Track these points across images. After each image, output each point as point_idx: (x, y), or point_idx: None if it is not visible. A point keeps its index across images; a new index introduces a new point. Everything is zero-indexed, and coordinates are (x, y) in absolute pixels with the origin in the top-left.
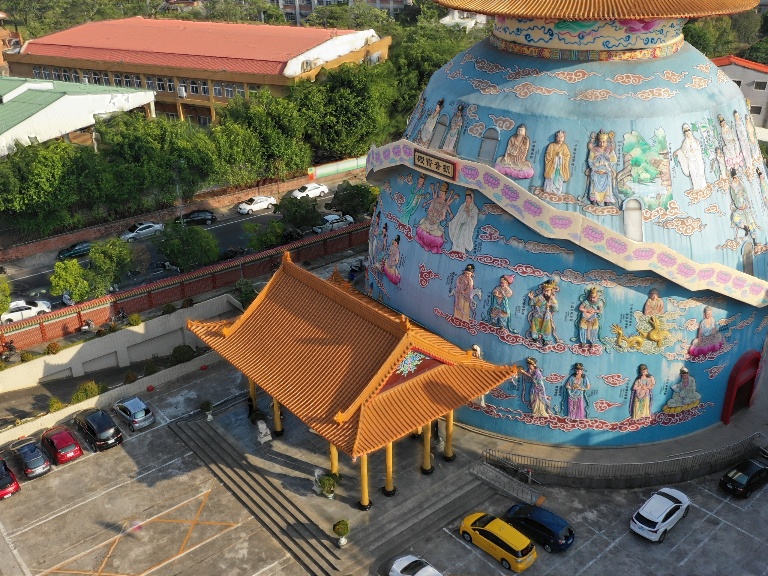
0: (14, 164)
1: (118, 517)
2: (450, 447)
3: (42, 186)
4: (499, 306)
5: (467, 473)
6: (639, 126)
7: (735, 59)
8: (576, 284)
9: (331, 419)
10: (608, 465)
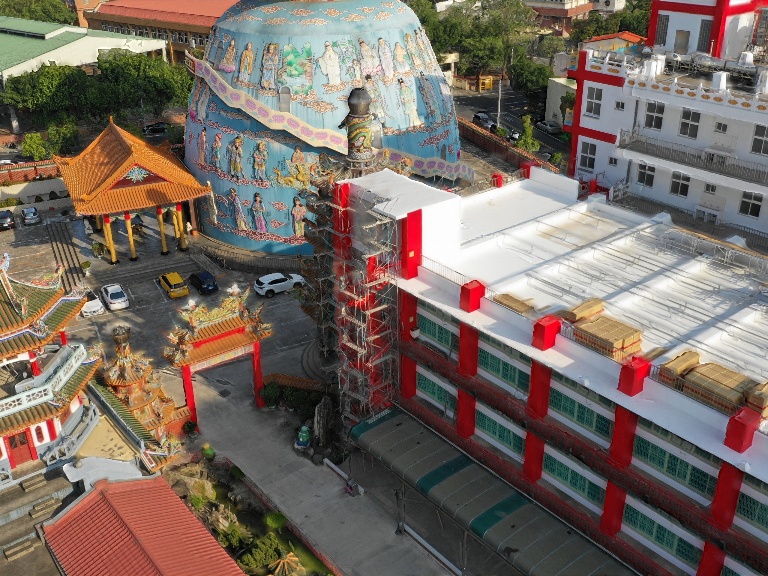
0: (31, 76)
1: None
2: (183, 242)
3: (44, 91)
4: (215, 153)
5: (188, 257)
6: (294, 41)
7: (628, 34)
8: (252, 139)
9: None
10: (266, 258)
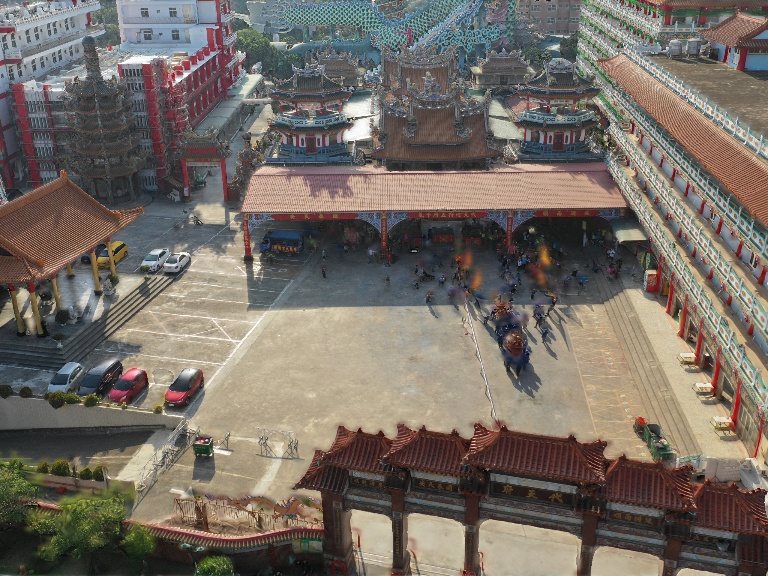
0: None
1: (176, 342)
2: None
3: None
4: None
5: None
6: None
7: None
8: None
9: (116, 221)
10: None
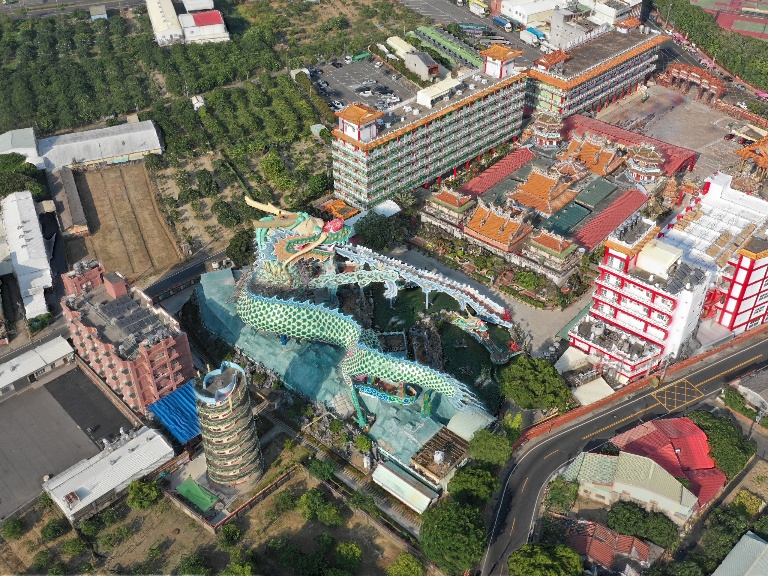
0: None
1: None
2: None
3: None
4: None
5: None
6: None
7: None
8: None
9: None
10: None
